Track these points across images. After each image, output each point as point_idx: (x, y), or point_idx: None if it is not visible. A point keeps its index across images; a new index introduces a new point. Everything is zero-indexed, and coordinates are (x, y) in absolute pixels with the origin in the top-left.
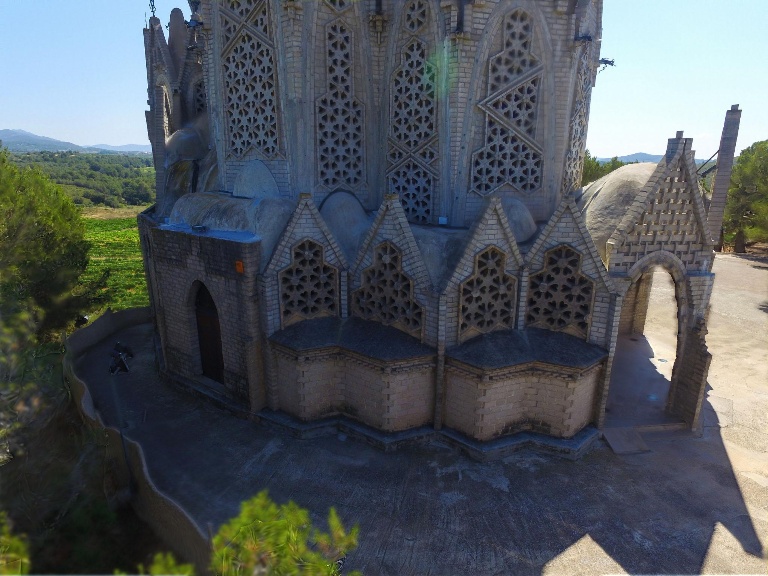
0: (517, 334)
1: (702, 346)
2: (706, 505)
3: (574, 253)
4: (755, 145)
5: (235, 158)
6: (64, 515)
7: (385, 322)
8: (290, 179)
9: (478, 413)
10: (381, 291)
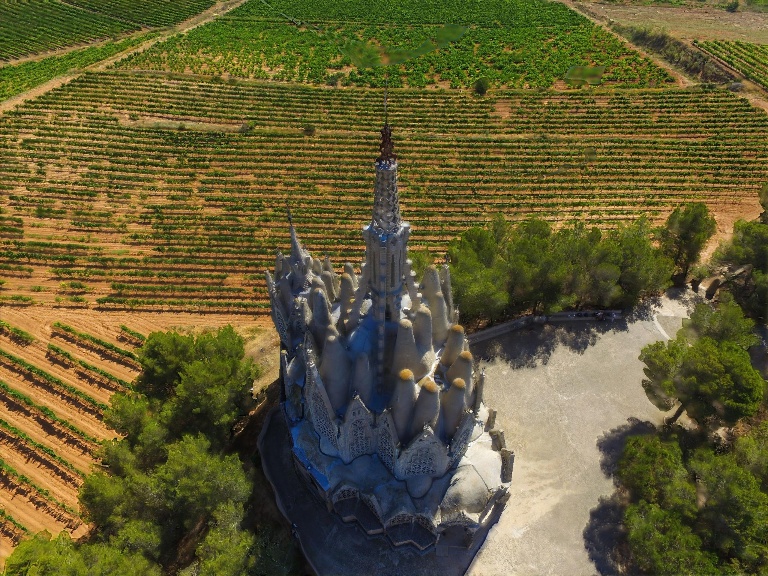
0: (411, 526)
1: (471, 539)
2: None
3: None
4: None
5: None
6: None
7: None
8: None
9: (394, 543)
10: None
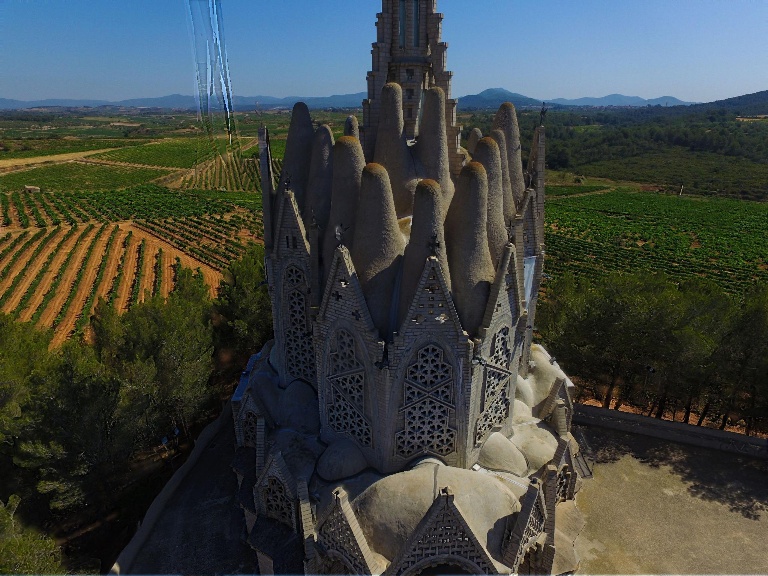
0: (290, 535)
1: None
2: None
3: None
4: None
5: None
6: (125, 487)
7: None
8: None
9: None
10: None
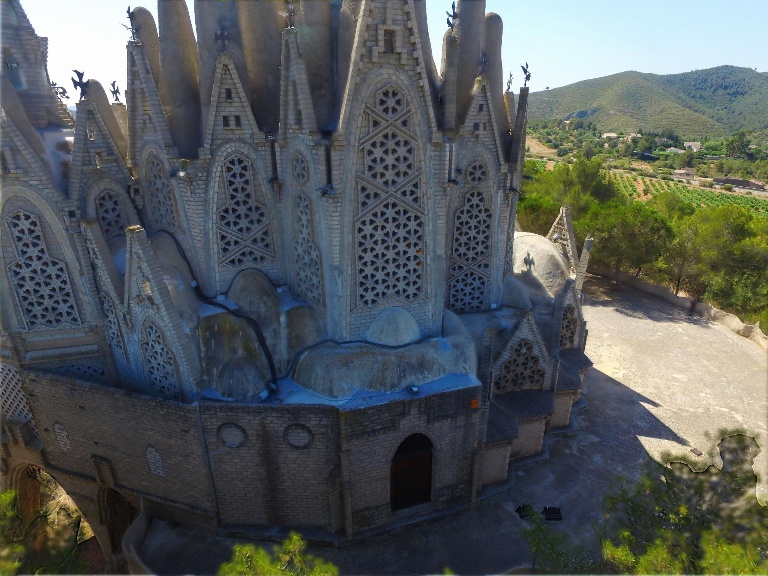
0: None
1: None
2: (629, 397)
3: (571, 308)
4: None
5: (368, 310)
6: None
7: (517, 389)
8: (432, 315)
9: None
10: (514, 371)
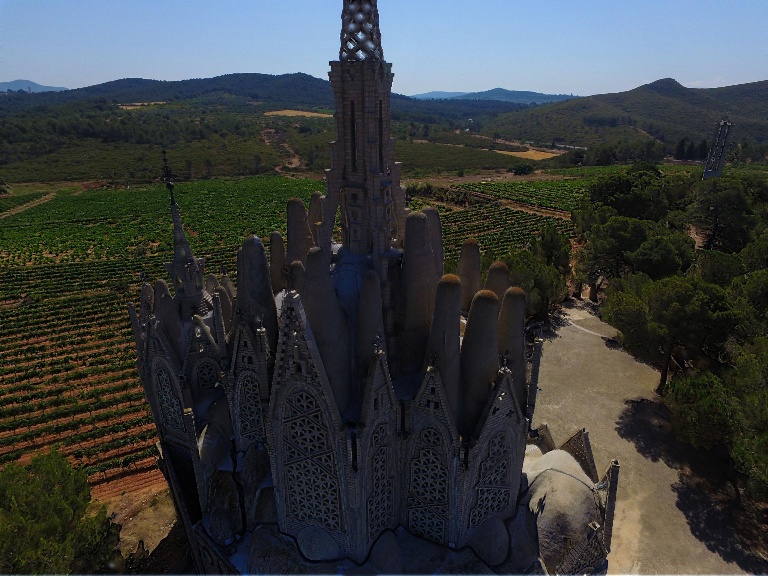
0: None
1: None
2: None
3: None
4: (599, 179)
5: None
6: None
7: None
8: (349, 545)
9: None
10: None
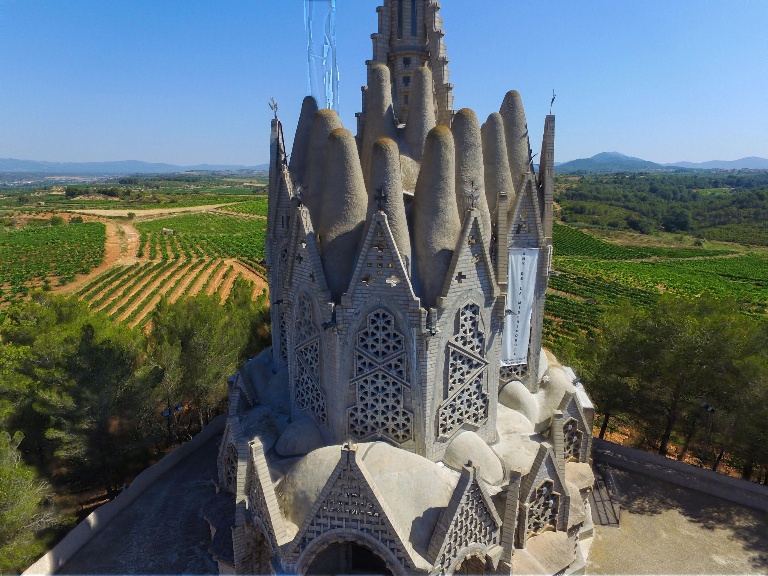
0: None
1: None
2: None
3: None
4: None
5: None
6: (126, 452)
7: None
8: None
9: None
10: None
